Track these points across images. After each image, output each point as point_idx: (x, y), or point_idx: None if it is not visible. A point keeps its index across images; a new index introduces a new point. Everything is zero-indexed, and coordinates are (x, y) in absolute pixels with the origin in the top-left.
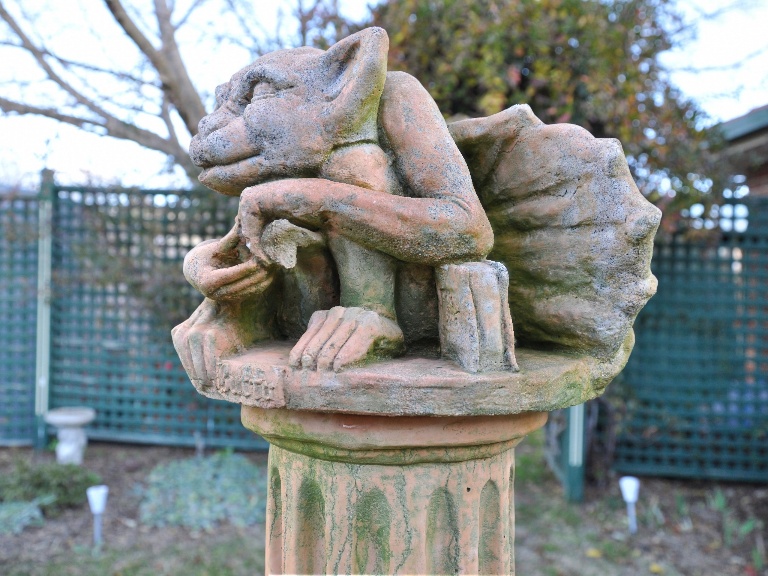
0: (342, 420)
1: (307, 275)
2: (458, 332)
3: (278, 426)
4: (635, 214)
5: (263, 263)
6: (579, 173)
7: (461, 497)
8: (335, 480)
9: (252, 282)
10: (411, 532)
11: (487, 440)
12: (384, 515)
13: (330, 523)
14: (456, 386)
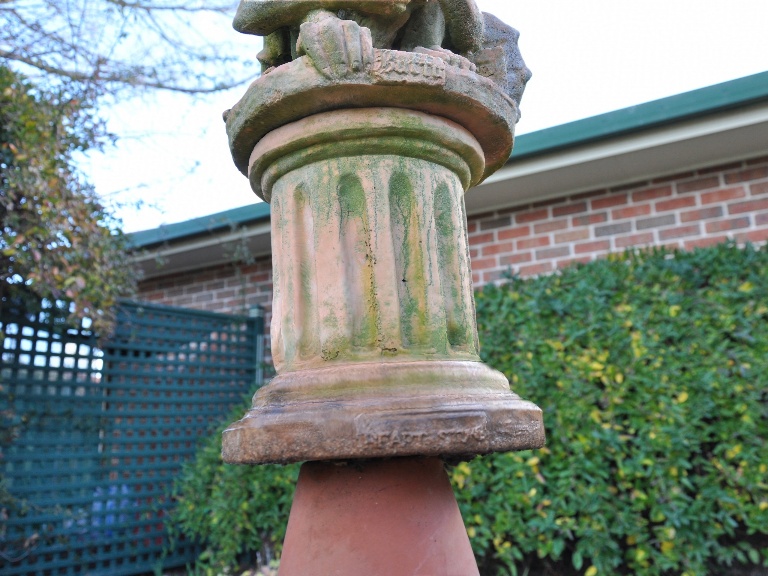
0: (445, 120)
1: (380, 30)
2: None
3: (397, 119)
4: None
5: None
6: (499, 38)
7: None
8: (423, 171)
9: None
10: None
11: None
12: (446, 203)
13: (422, 201)
14: None
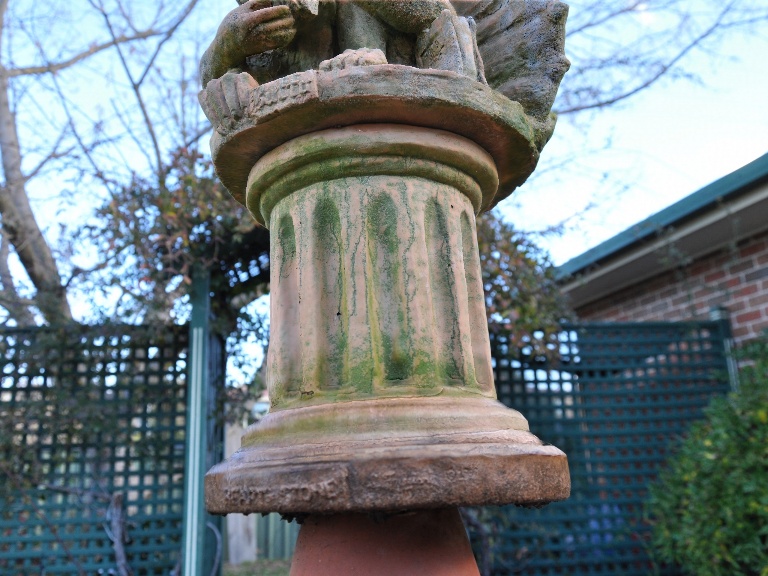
0: (358, 127)
1: (312, 57)
2: (444, 60)
3: (300, 147)
4: (553, 2)
5: (294, 8)
6: None
7: (448, 209)
8: (348, 190)
9: (284, 24)
10: (414, 225)
11: (467, 154)
12: (390, 215)
13: (346, 223)
14: (451, 76)
